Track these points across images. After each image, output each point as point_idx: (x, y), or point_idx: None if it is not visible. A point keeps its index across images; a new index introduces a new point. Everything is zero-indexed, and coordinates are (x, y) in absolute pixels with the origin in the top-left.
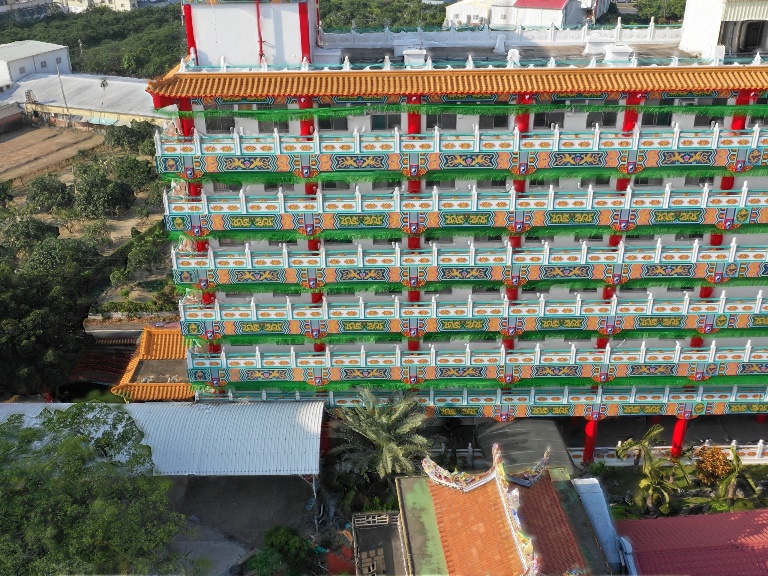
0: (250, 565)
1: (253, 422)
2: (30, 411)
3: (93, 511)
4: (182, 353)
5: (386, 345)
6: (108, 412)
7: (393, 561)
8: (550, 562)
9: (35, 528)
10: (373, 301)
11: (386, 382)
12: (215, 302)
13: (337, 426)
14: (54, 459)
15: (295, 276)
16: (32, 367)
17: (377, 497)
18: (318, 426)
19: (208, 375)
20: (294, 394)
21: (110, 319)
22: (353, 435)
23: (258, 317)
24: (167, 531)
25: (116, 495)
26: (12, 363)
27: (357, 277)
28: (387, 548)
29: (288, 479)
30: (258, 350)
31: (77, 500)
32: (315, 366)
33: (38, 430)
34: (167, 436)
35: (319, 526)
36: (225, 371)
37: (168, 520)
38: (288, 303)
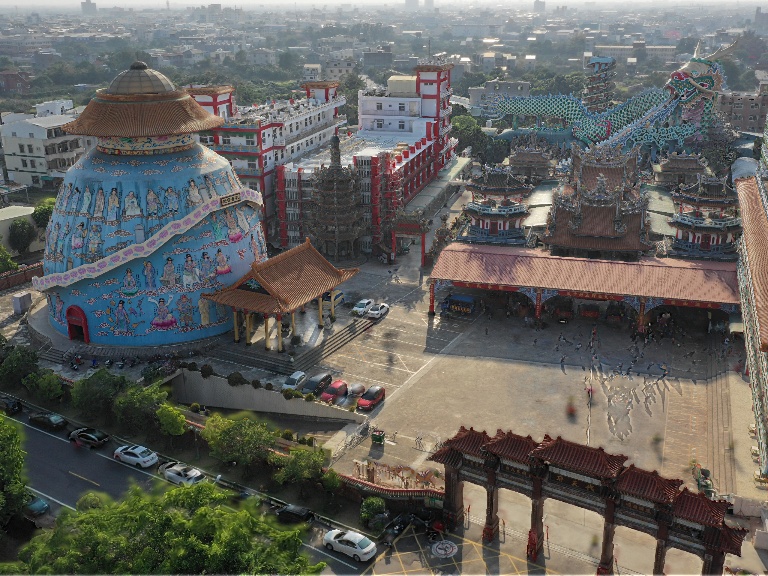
0: None
1: None
2: None
3: None
4: None
5: None
6: None
7: None
8: (676, 162)
9: None
10: None
11: None
12: None
13: None
14: None
15: None
16: None
17: None
18: None
19: None
20: None
21: None
22: None
23: None
24: None
25: None
26: None
27: None
28: None
29: None
30: None
31: (707, 158)
32: None
33: None
34: None
35: None
36: None
37: None
38: None
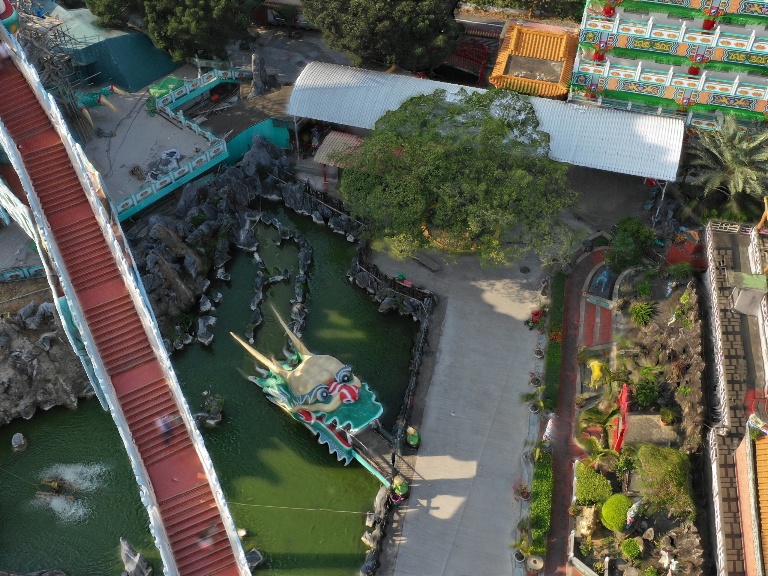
0: (598, 242)
1: (622, 128)
2: (433, 87)
3: (511, 177)
4: (546, 54)
5: (758, 78)
6: (517, 100)
7: (740, 261)
8: None
9: (469, 181)
10: (764, 36)
11: (748, 112)
12: (616, 16)
13: (695, 144)
14: (482, 131)
15: (699, 2)
16: (424, 47)
17: (715, 210)
18: (680, 141)
19: (589, 80)
20: (657, 109)
21: (459, 8)
22: (707, 154)
23: (651, 35)
24: (563, 203)
25: (525, 168)
26: (408, 41)
27: (758, 11)
28: (735, 251)
29: (628, 181)
30: (640, 65)
31: (500, 166)
32: (687, 87)
33: (460, 105)
34: (549, 127)
35: (656, 224)
36: (605, 79)
37: (562, 195)
38: (683, 26)
